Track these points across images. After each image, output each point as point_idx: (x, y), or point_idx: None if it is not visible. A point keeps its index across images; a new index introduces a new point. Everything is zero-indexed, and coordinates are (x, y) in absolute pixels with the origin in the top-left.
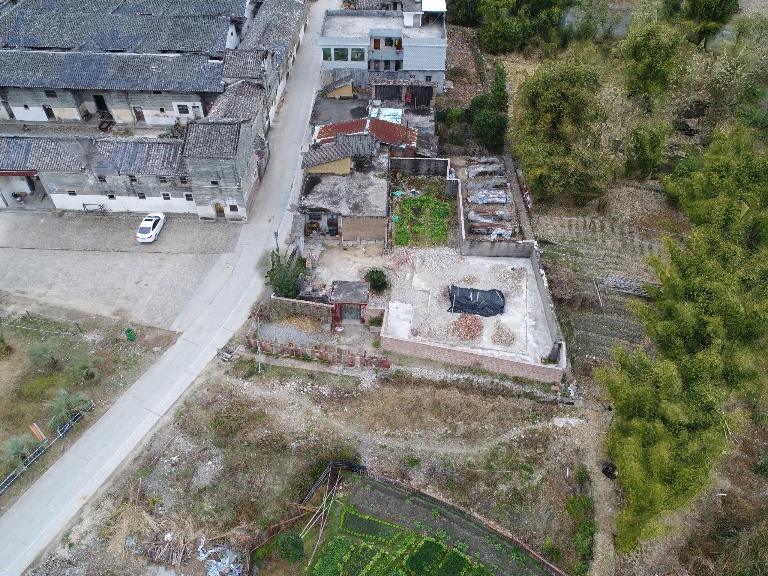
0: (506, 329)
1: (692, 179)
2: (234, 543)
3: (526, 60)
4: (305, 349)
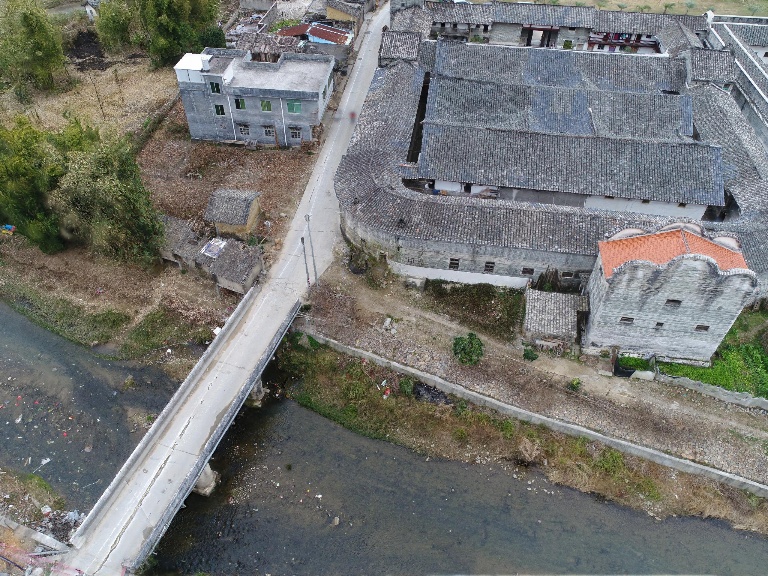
0: None
1: None
2: None
3: None
4: None
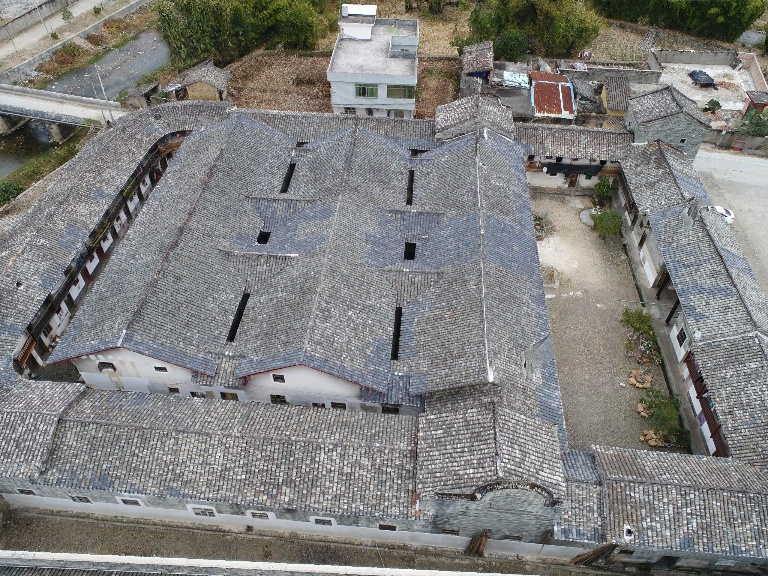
0: (720, 75)
1: None
2: None
3: (328, 39)
4: None
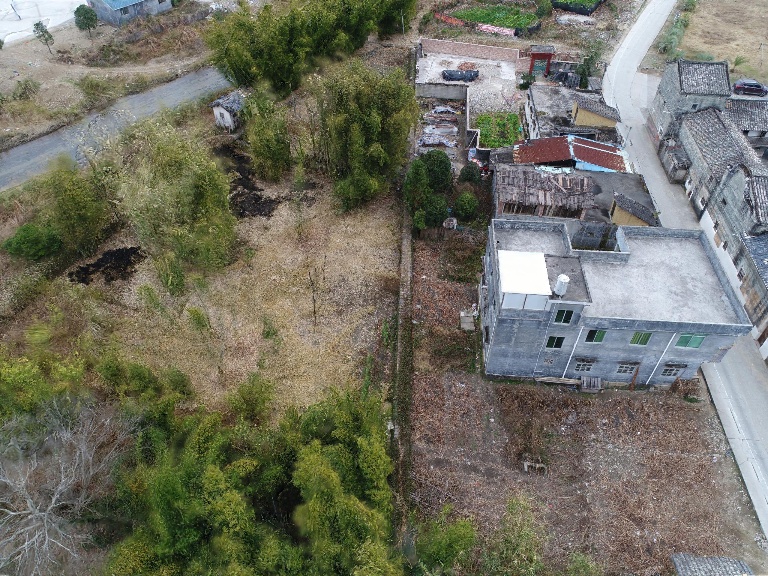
0: (444, 66)
1: (299, 53)
2: (563, 25)
3: None
4: (560, 55)
